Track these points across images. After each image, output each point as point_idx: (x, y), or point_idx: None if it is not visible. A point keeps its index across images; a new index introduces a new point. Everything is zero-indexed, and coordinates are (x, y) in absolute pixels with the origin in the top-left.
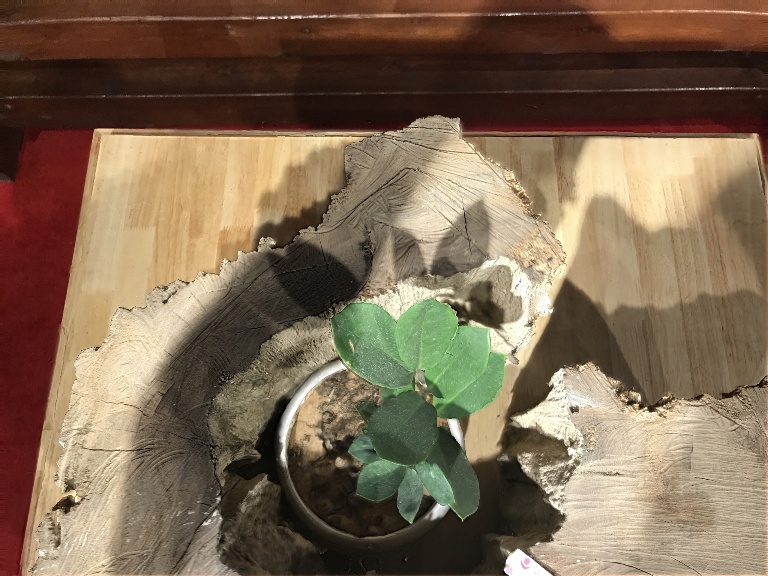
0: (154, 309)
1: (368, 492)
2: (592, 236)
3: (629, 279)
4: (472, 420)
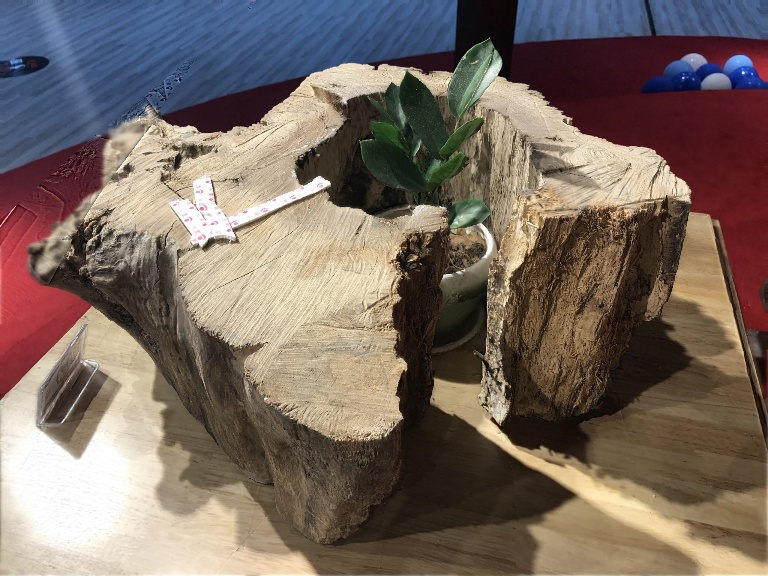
0: (526, 91)
1: (391, 93)
2: (636, 542)
3: (574, 567)
4: (435, 380)
